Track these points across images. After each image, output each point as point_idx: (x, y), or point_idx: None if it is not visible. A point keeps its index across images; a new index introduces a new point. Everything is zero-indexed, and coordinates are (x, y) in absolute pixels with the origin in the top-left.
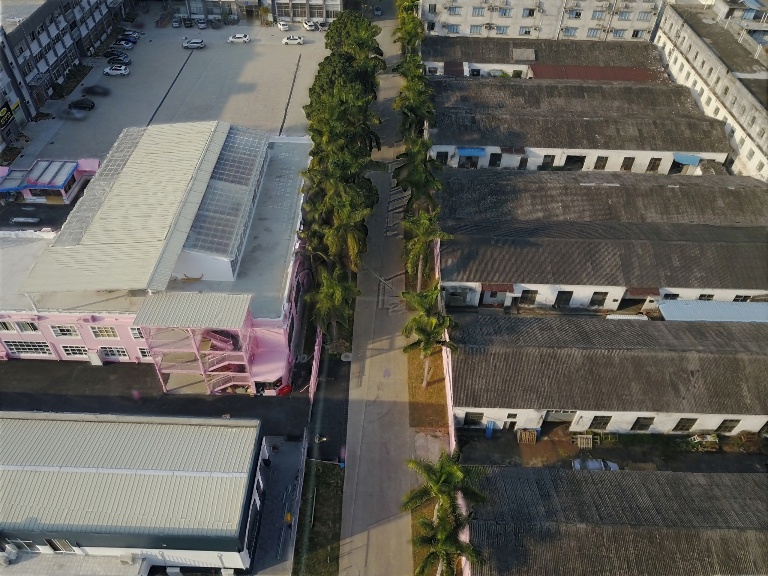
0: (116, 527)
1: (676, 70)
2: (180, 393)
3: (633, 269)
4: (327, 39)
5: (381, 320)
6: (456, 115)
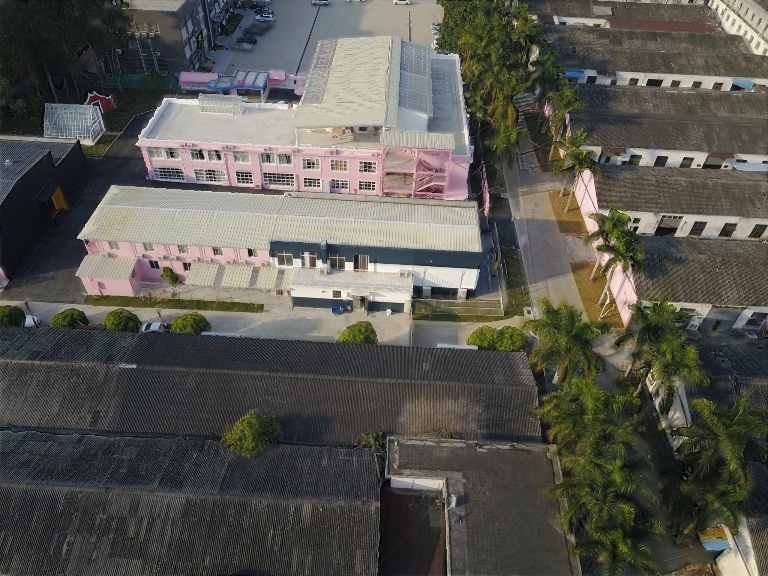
0: None
1: (728, 25)
2: None
3: (713, 141)
4: None
5: (524, 176)
6: (560, 46)
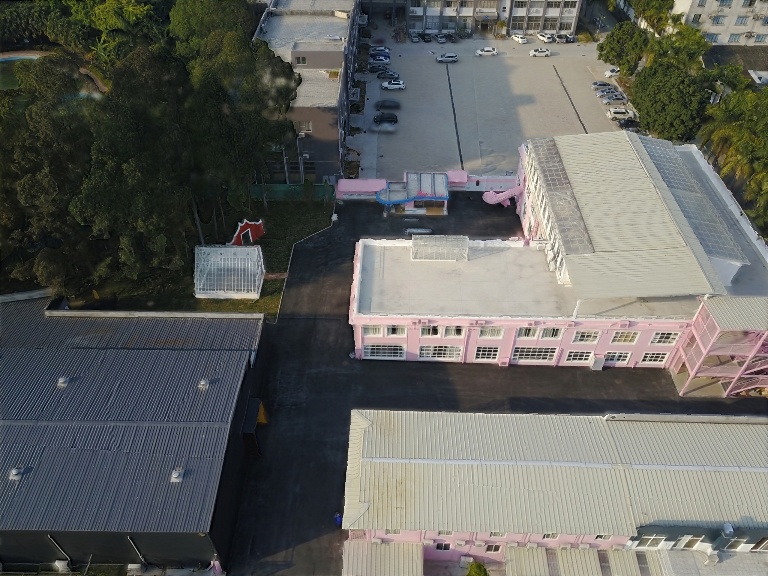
0: None
1: None
2: (696, 396)
3: None
4: (600, 50)
5: None
6: None
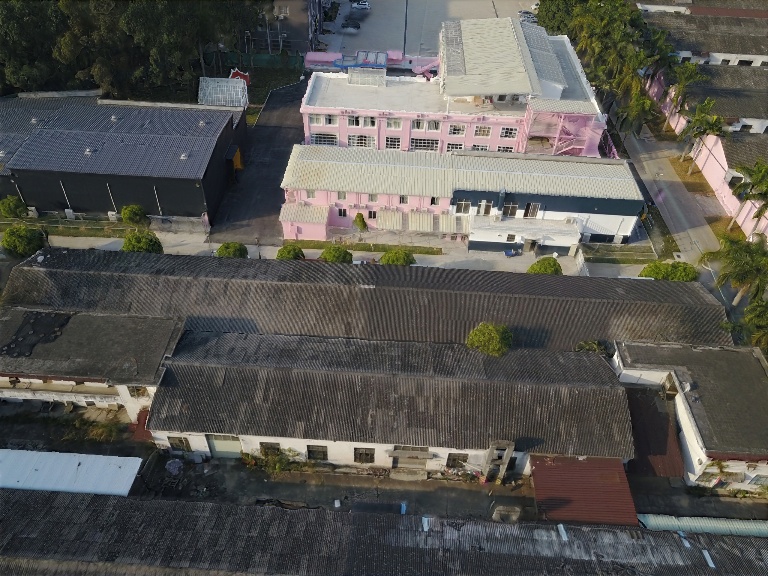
0: None
1: None
2: None
3: None
4: None
5: (642, 144)
6: None
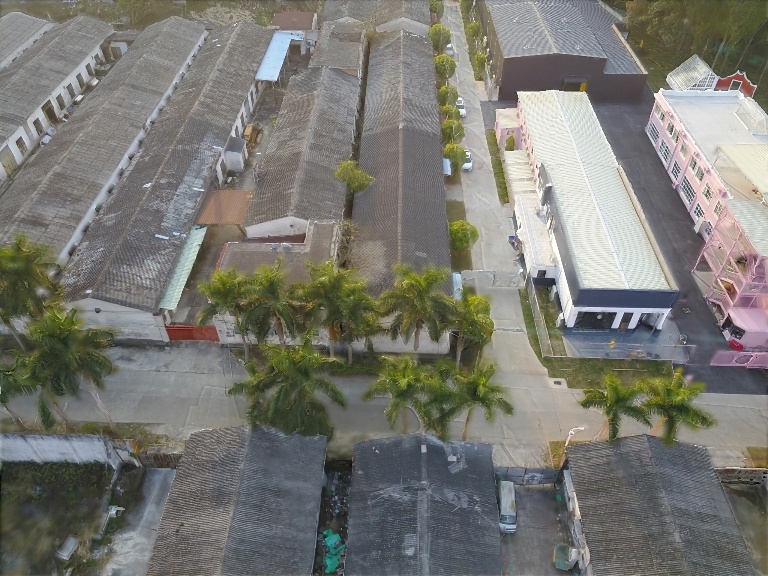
0: (569, 237)
1: None
2: (696, 280)
3: None
4: None
5: None
6: None
